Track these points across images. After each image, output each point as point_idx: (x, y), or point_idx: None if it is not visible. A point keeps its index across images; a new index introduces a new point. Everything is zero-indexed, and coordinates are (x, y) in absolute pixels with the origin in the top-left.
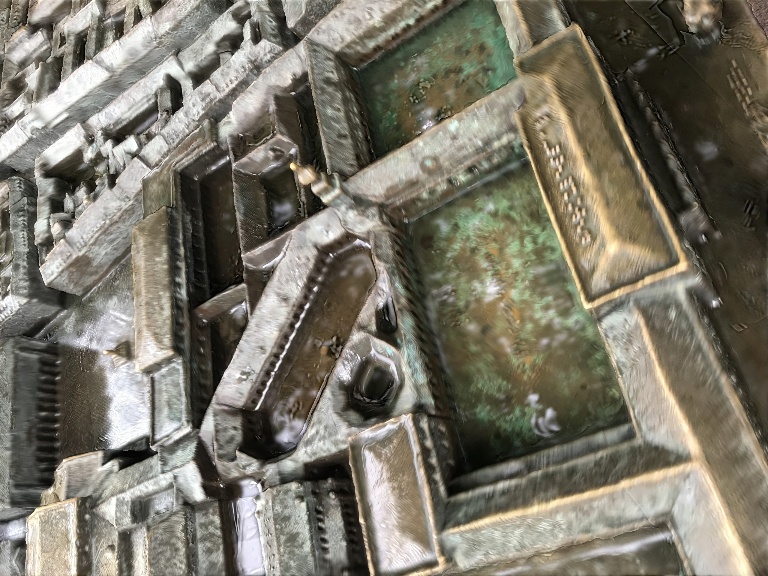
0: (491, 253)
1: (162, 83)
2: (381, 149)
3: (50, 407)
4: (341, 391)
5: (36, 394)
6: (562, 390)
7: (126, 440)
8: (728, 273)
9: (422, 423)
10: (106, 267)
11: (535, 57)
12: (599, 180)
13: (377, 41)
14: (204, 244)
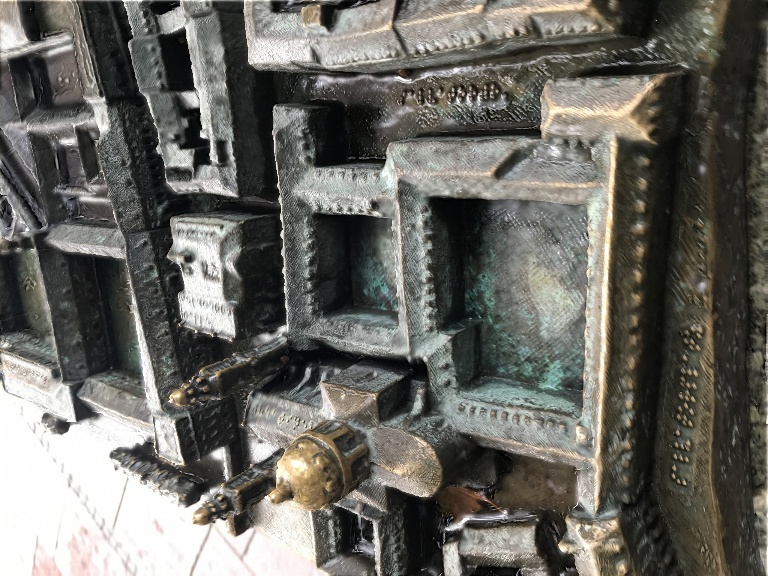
0: None
1: None
2: None
3: None
4: None
5: None
6: (39, 297)
7: None
8: None
9: None
10: None
11: None
12: None
13: None
14: None
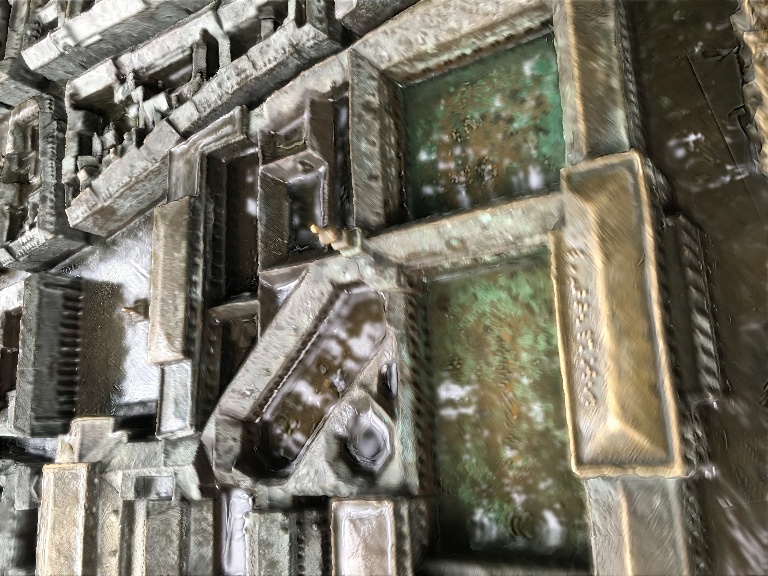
0: (503, 338)
1: (199, 38)
2: (414, 184)
3: (71, 342)
4: (335, 440)
5: (58, 330)
6: (542, 499)
7: (138, 397)
8: (729, 446)
9: (403, 510)
10: (131, 216)
11: (584, 175)
12: (617, 349)
13: (428, 64)
14: (225, 235)
